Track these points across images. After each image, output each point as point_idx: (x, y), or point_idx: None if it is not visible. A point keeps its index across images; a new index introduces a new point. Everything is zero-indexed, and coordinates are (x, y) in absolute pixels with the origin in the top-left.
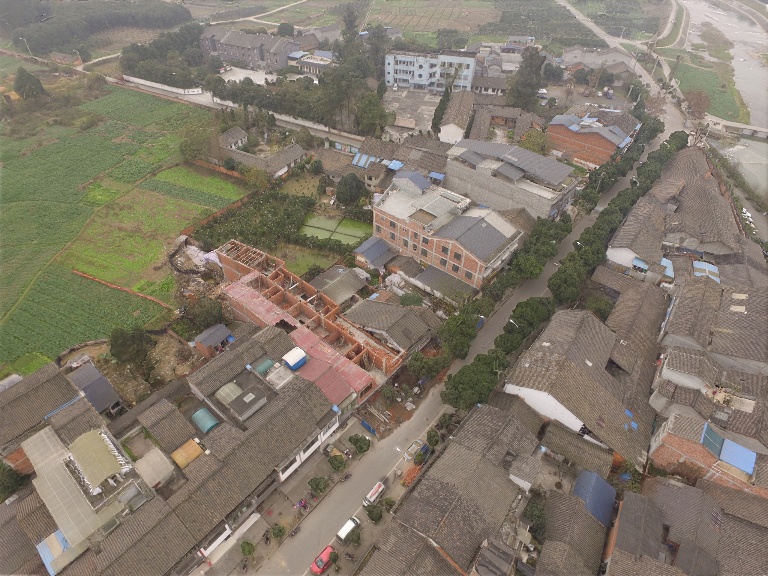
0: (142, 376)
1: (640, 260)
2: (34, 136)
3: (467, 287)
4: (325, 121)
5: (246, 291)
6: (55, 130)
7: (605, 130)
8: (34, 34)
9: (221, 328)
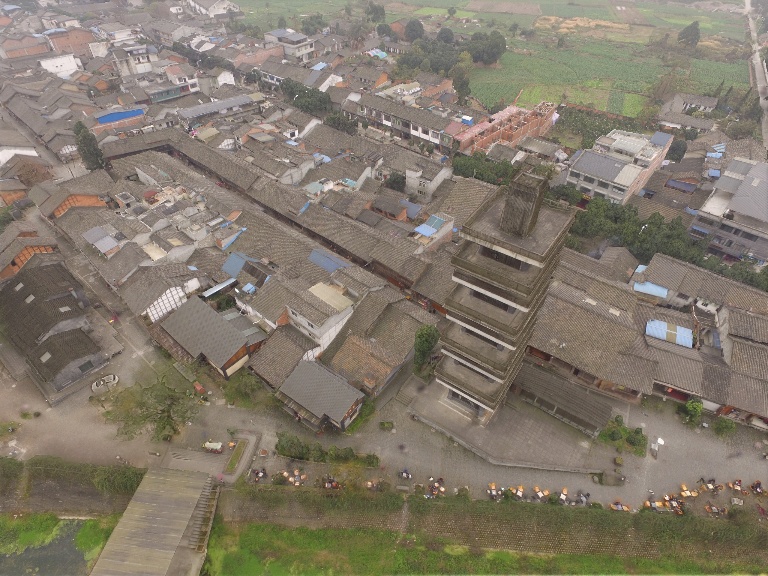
0: None
1: None
2: (641, 57)
3: None
4: None
5: (513, 110)
6: (654, 60)
7: None
8: None
9: (490, 115)
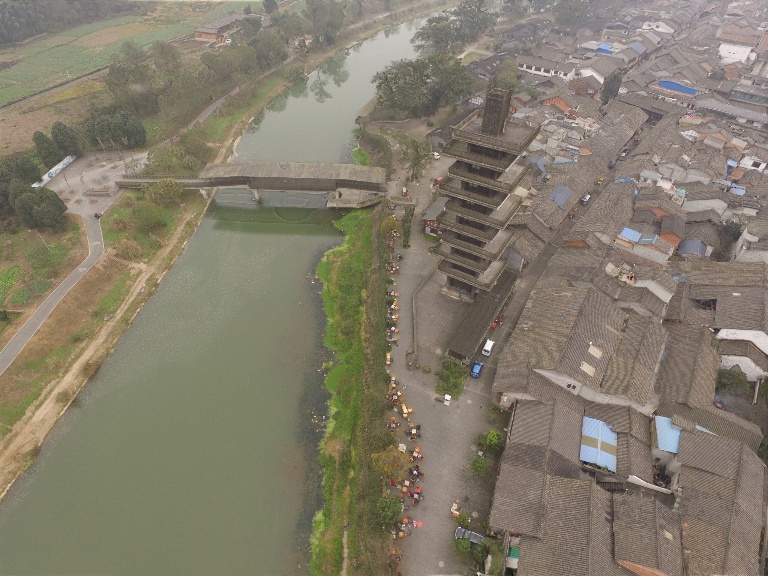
0: None
1: None
2: None
3: None
4: None
5: None
6: None
7: None
8: None
9: None
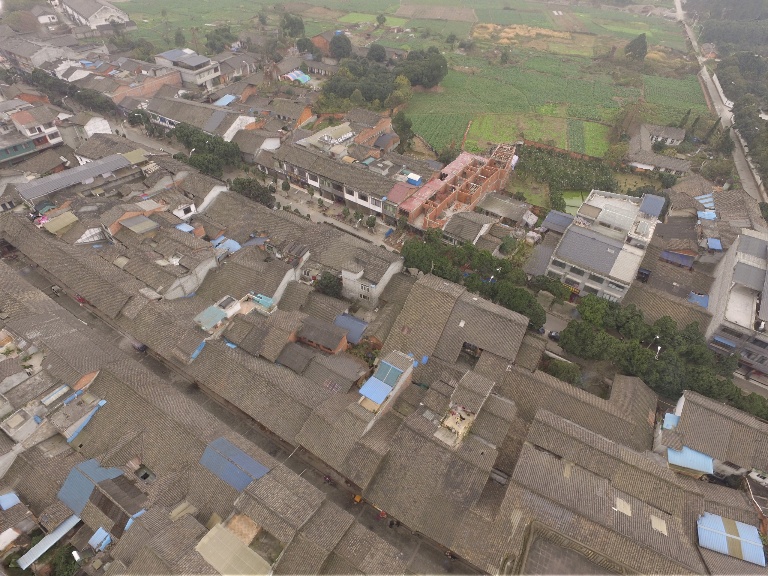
0: (398, 149)
1: (678, 421)
2: (590, 74)
3: (542, 272)
4: (758, 170)
5: (467, 159)
6: (604, 77)
7: None
8: (715, 26)
9: (440, 164)
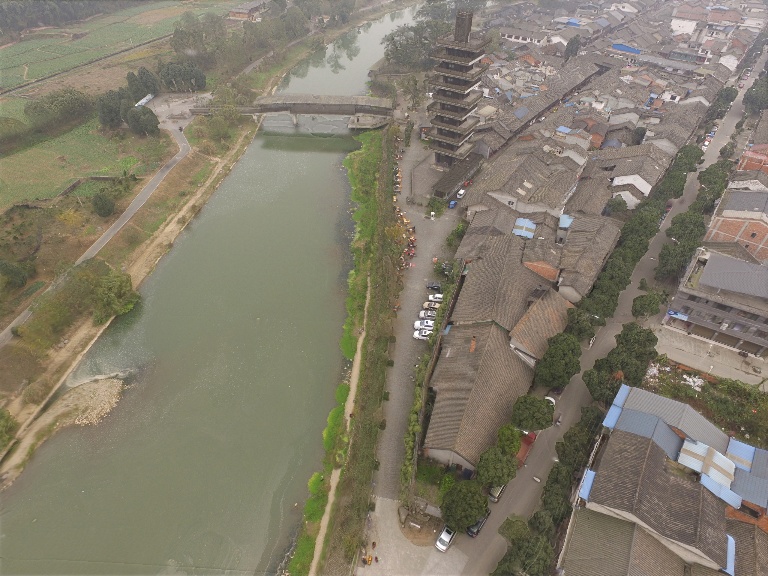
0: None
1: None
2: None
3: None
4: None
5: None
6: None
7: (673, 417)
8: None
9: None
